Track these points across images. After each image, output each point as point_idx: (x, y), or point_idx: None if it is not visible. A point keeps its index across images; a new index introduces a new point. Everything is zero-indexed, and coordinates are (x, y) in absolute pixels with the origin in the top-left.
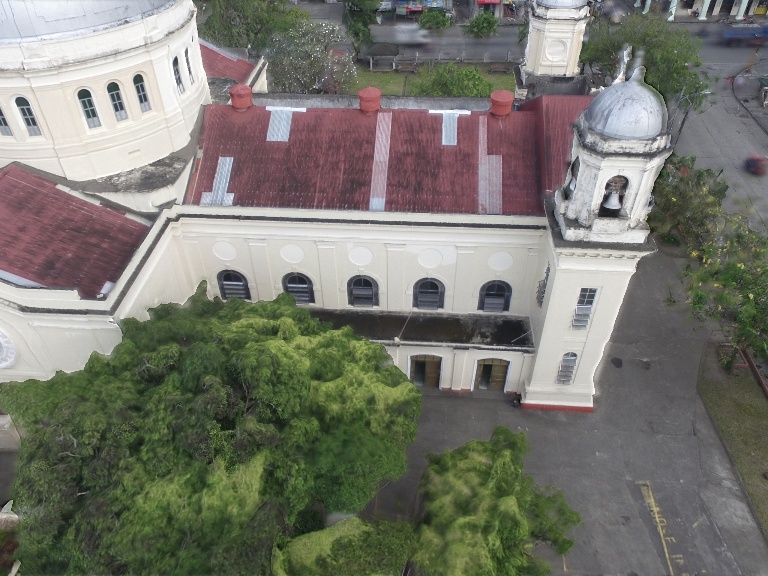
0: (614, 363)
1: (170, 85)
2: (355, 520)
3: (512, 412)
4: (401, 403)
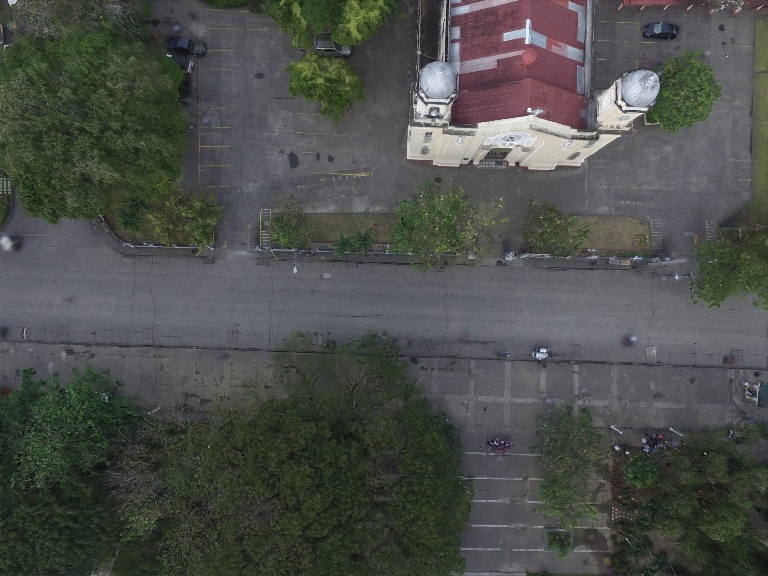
0: (437, 178)
1: None
2: (306, 22)
3: (405, 124)
4: (351, 34)
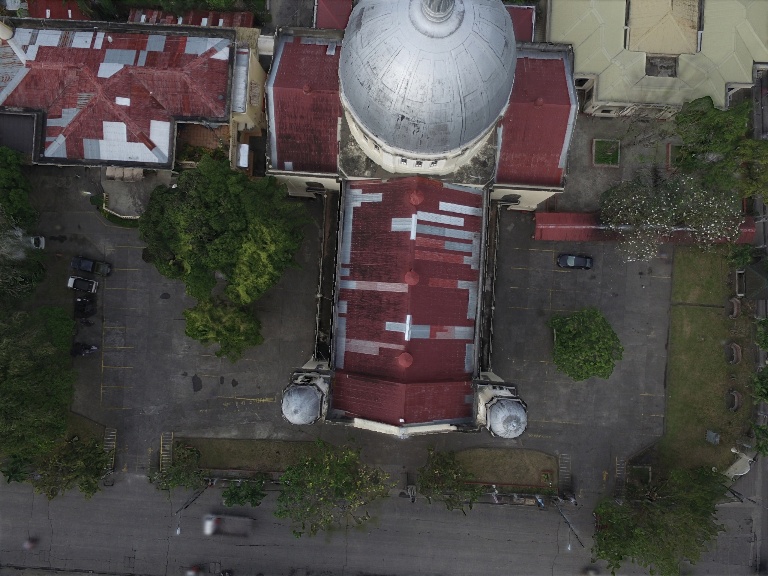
0: None
1: (391, 160)
2: None
3: (311, 350)
4: (240, 296)
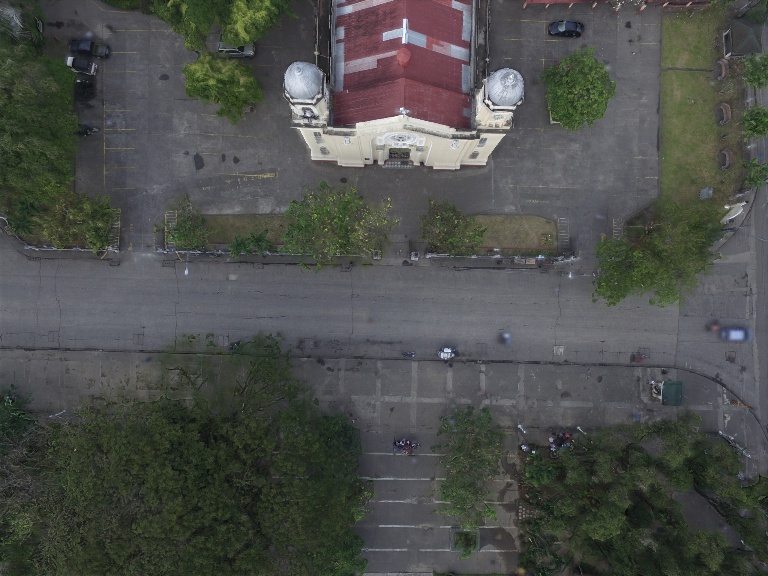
0: (343, 178)
1: None
2: None
3: None
4: (239, 35)
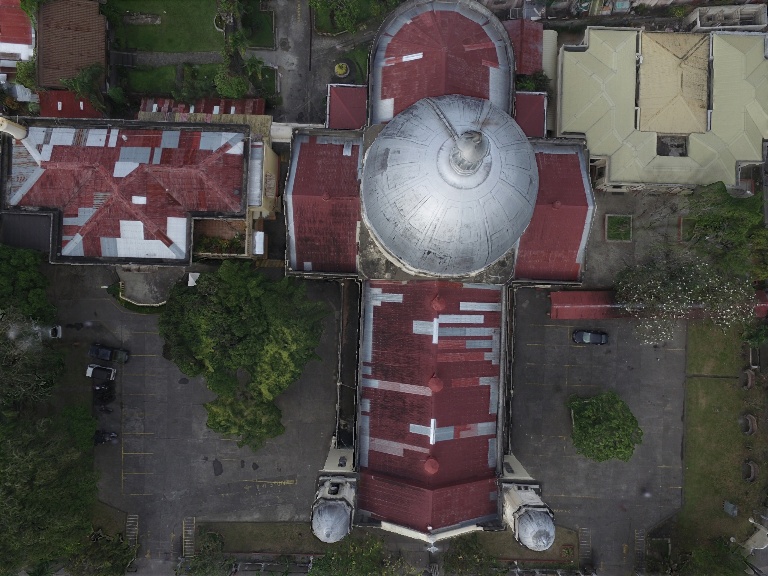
0: None
1: None
2: None
3: (331, 431)
4: (262, 394)
